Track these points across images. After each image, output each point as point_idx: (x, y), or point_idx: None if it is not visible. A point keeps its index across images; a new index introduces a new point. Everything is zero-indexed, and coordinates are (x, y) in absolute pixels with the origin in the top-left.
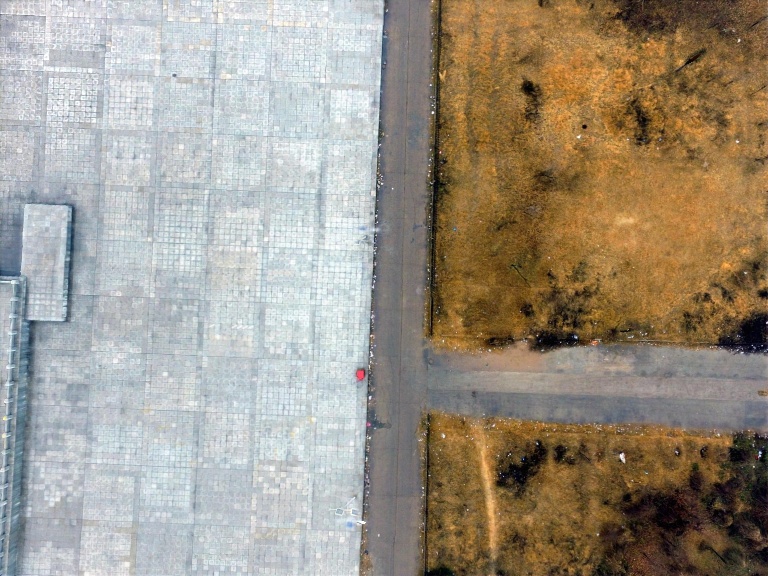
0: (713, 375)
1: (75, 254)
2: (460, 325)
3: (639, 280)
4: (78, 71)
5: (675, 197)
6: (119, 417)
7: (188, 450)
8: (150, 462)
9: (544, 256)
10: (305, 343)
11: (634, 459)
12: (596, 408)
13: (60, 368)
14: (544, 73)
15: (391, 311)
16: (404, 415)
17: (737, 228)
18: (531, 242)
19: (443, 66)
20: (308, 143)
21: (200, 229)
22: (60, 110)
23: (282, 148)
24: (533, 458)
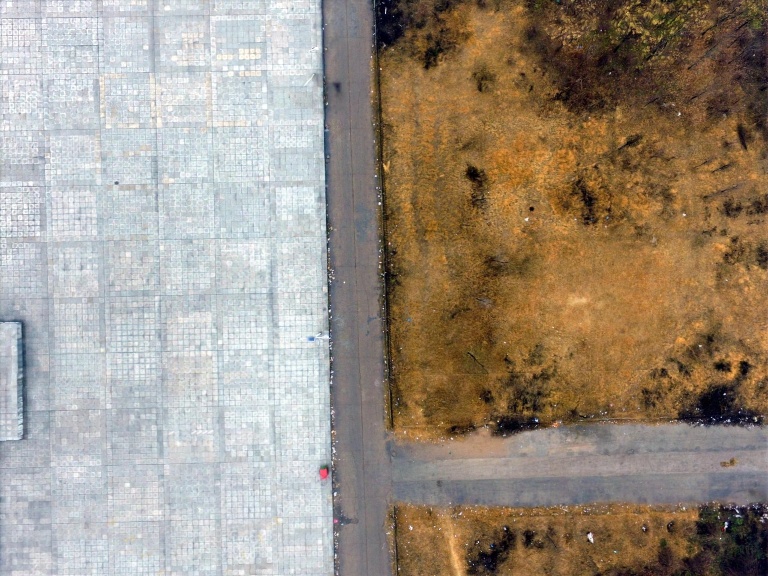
0: (675, 449)
1: (28, 370)
2: (420, 415)
3: (595, 359)
4: (18, 185)
5: (626, 274)
6: (83, 532)
7: (155, 560)
8: (118, 575)
9: (500, 341)
10: (266, 444)
11: (602, 539)
12: (561, 489)
13: (20, 486)
14: (488, 158)
15: (351, 406)
16: (370, 509)
17: (689, 301)
18: (486, 328)
19: (387, 157)
20: (256, 243)
21: (153, 336)
22: (3, 226)
23: (230, 249)
24: (501, 544)
